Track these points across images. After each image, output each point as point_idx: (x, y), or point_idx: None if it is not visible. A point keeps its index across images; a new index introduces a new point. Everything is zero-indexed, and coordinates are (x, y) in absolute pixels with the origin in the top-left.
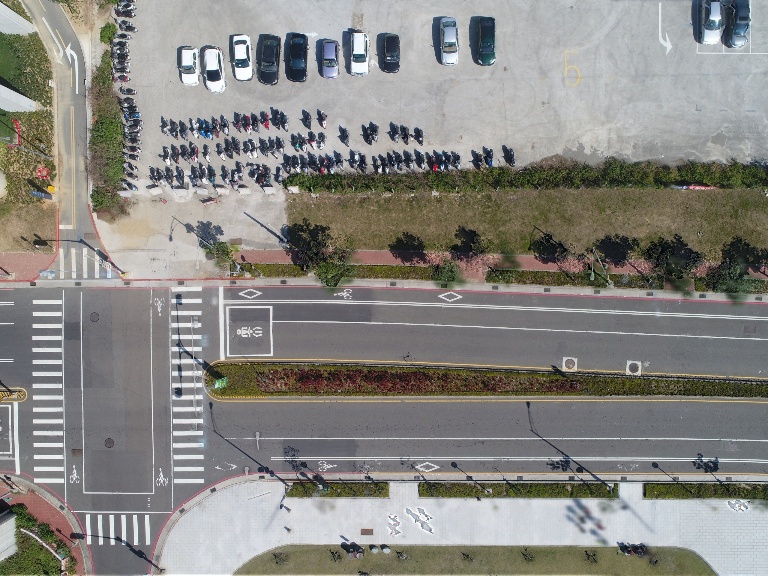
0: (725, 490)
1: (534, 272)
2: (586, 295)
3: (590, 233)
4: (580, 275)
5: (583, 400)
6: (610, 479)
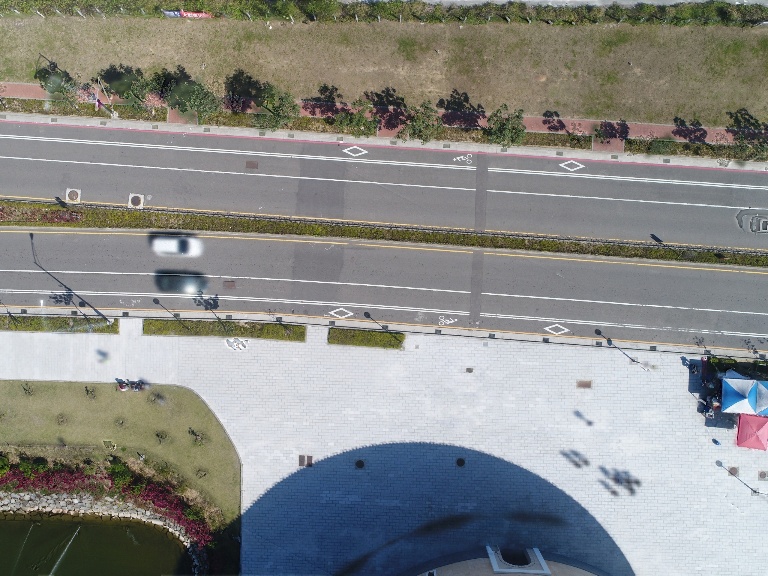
0: (222, 327)
1: (40, 101)
2: (92, 126)
3: (95, 62)
4: (84, 105)
5: (86, 233)
6: (112, 314)
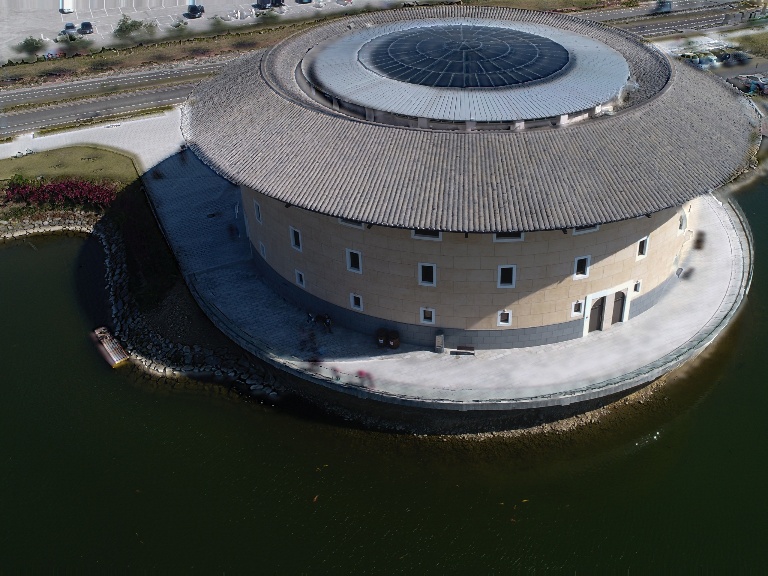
0: (99, 122)
1: None
2: None
3: None
4: None
5: None
6: None
